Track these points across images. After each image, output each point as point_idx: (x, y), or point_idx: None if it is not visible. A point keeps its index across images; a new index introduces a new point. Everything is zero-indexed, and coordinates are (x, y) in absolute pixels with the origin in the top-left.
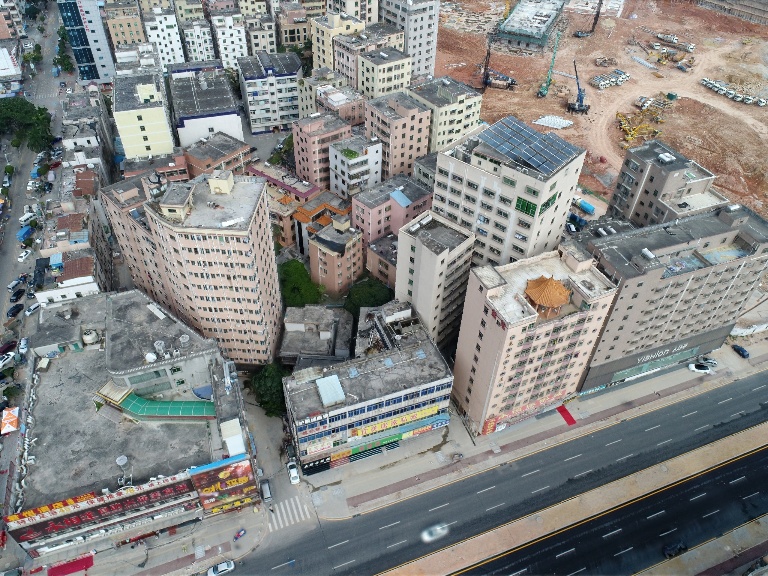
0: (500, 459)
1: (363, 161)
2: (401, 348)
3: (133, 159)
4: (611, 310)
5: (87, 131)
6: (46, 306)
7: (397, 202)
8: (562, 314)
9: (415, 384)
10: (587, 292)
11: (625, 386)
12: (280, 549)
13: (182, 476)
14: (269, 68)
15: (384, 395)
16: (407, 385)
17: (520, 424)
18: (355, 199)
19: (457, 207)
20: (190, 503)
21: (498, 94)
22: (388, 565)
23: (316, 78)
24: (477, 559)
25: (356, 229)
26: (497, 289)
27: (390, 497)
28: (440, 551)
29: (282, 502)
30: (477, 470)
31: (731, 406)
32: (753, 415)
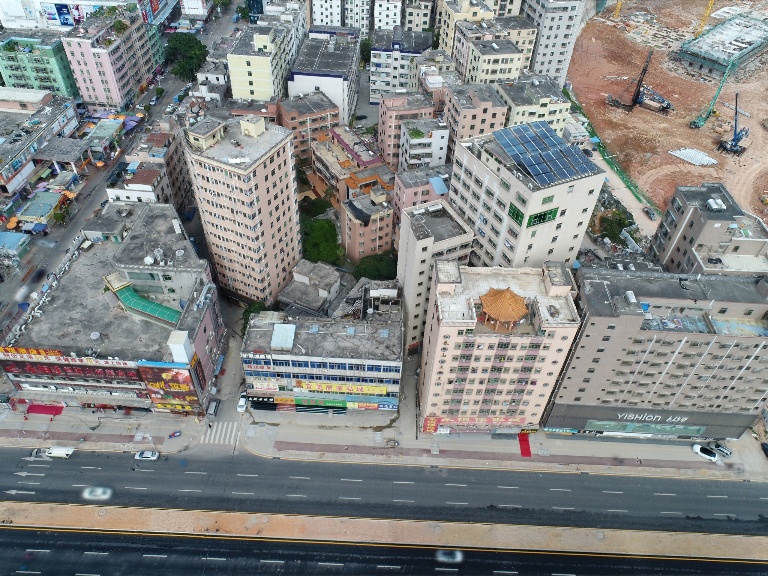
0: (433, 461)
1: (426, 143)
2: (369, 322)
3: (236, 99)
4: (576, 346)
5: (220, 70)
6: (113, 202)
7: (433, 188)
8: (514, 332)
9: (363, 357)
10: (547, 317)
11: (606, 440)
12: (200, 459)
13: (132, 364)
14: (396, 43)
15: (328, 357)
16: (355, 356)
17: (471, 436)
18: (397, 176)
19: (466, 202)
20: (141, 392)
21: (646, 115)
22: (279, 510)
23: (426, 58)
24: (359, 538)
25: (389, 205)
26: (451, 286)
27: (313, 454)
28: (330, 517)
29: (222, 422)
30: (405, 462)
31: (721, 504)
32: (743, 523)
